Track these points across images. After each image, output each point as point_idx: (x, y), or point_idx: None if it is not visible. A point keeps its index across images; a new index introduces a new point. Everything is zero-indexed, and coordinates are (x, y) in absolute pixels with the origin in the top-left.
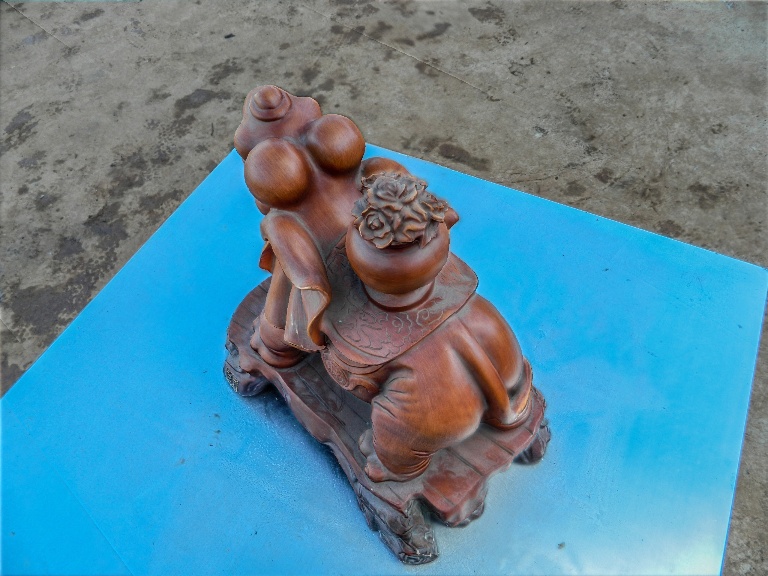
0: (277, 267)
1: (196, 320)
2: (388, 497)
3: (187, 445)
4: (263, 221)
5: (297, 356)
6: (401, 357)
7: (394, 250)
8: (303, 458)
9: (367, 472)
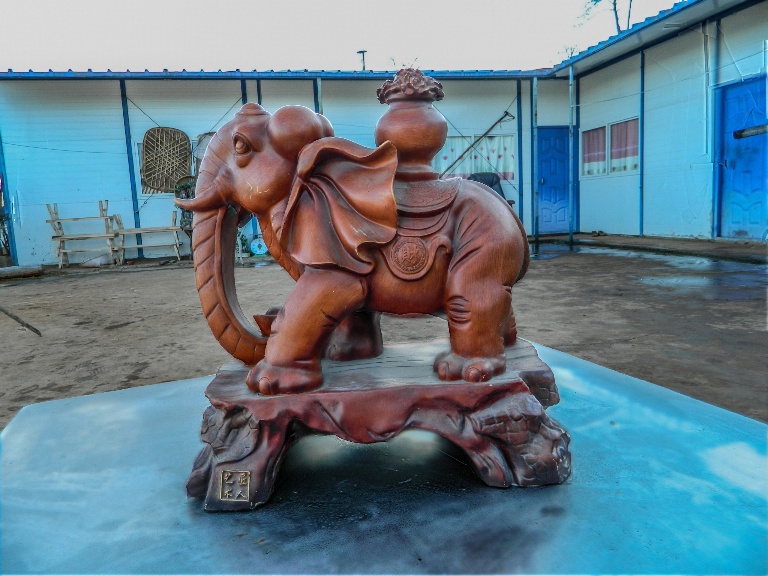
0: (307, 218)
1: (109, 509)
2: (507, 381)
3: (236, 569)
4: (307, 147)
5: (320, 372)
6: (458, 195)
7: (428, 102)
8: (382, 498)
9: (476, 371)
